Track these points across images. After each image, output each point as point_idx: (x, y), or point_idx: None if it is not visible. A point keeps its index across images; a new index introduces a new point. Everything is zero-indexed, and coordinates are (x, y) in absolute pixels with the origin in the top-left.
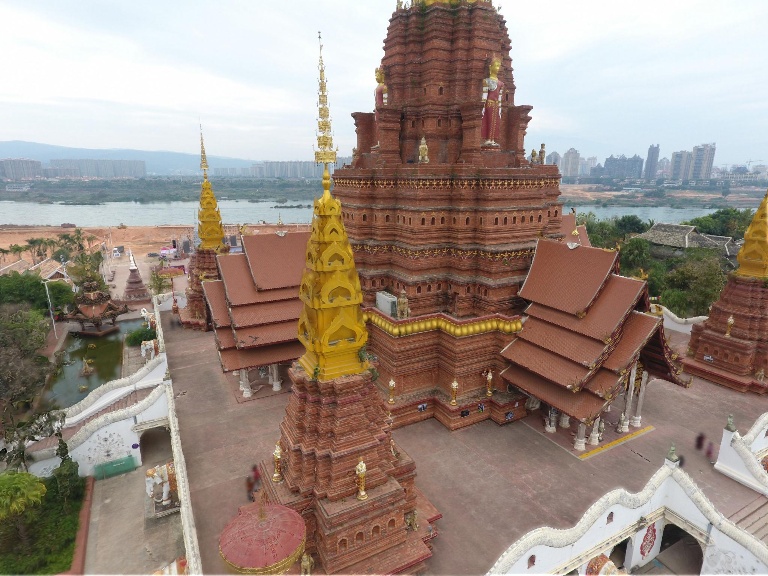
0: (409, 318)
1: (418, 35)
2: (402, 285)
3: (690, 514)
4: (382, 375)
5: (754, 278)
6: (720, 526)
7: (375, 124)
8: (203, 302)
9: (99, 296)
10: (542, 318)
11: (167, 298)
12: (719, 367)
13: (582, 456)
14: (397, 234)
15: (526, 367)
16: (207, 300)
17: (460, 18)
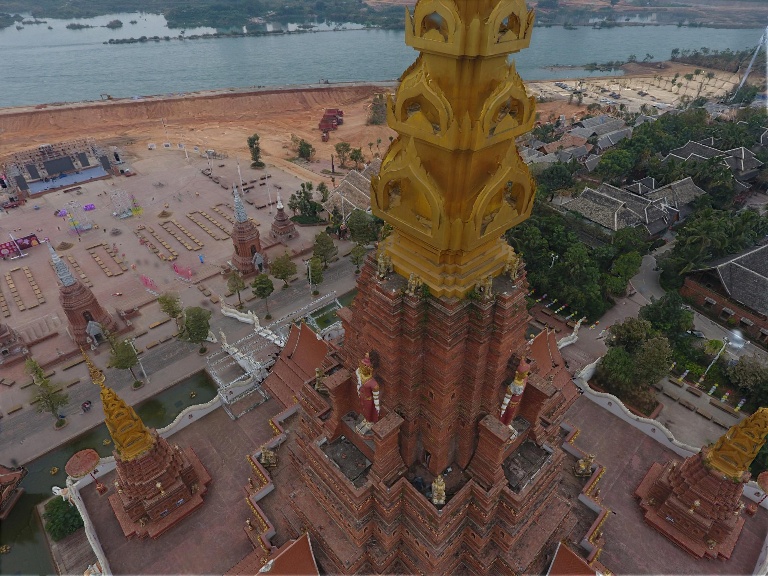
0: None
1: None
2: None
3: None
4: None
5: (726, 478)
6: None
7: (356, 392)
8: None
9: None
10: None
11: None
12: (678, 529)
13: None
14: None
15: None
16: None
17: (482, 322)
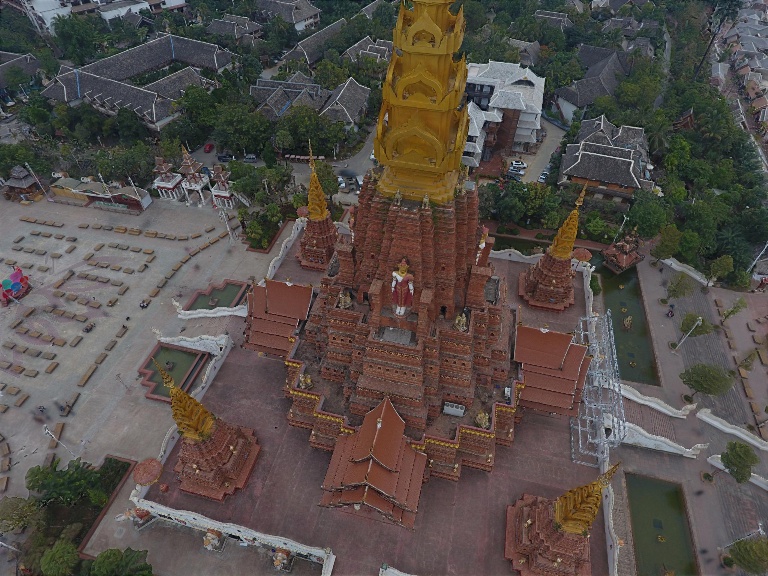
0: None
1: None
2: None
3: None
4: None
5: None
6: None
7: None
8: None
9: (622, 247)
10: None
11: None
12: None
13: None
14: None
15: None
16: None
17: None
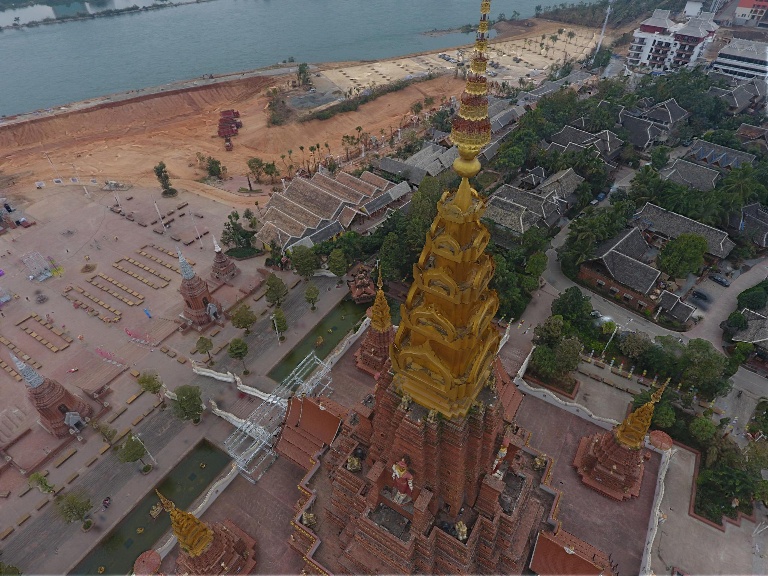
0: None
1: None
2: None
3: None
4: None
5: None
6: None
7: None
8: None
9: None
10: None
11: None
12: (605, 484)
13: None
14: None
15: None
16: None
17: (479, 427)
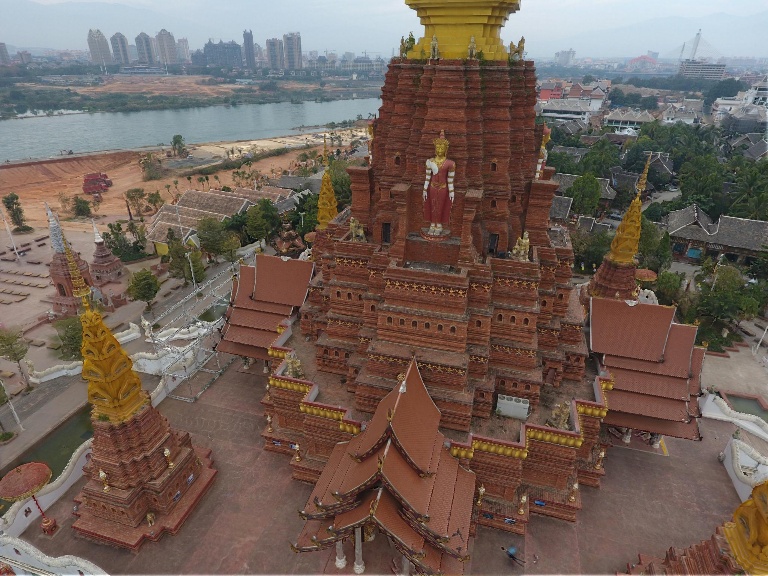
0: (575, 423)
1: (482, 98)
2: (524, 384)
3: (745, 462)
4: (534, 476)
5: None
6: (766, 463)
7: (419, 200)
8: (150, 495)
9: None
10: (625, 368)
11: (12, 518)
12: None
13: (665, 452)
14: (498, 332)
15: (639, 414)
16: (390, 532)
17: (523, 82)
